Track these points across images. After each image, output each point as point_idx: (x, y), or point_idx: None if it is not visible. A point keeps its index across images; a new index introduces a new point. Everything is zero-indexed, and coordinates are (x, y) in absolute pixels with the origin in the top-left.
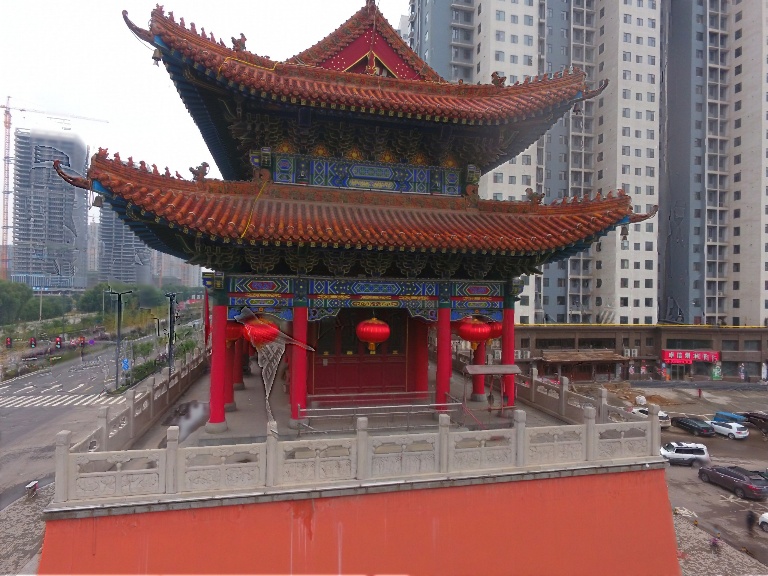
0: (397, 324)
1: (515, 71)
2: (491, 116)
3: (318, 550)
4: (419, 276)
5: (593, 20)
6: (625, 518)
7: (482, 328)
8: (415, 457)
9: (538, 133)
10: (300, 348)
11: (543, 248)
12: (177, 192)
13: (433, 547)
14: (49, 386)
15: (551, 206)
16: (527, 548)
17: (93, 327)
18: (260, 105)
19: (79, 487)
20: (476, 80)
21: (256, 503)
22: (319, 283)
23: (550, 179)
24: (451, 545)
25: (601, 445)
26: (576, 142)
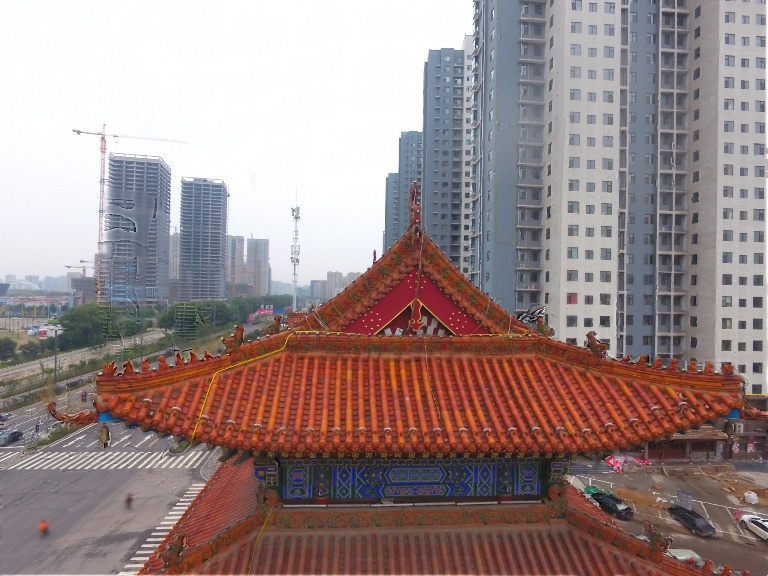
0: None
1: (593, 110)
2: (591, 448)
3: None
4: None
5: (686, 41)
6: None
7: None
8: None
9: None
10: None
11: None
12: None
13: None
14: (119, 438)
15: (684, 566)
16: None
17: None
18: None
19: None
20: (547, 120)
21: None
22: None
23: (634, 224)
24: None
25: None
26: (665, 180)
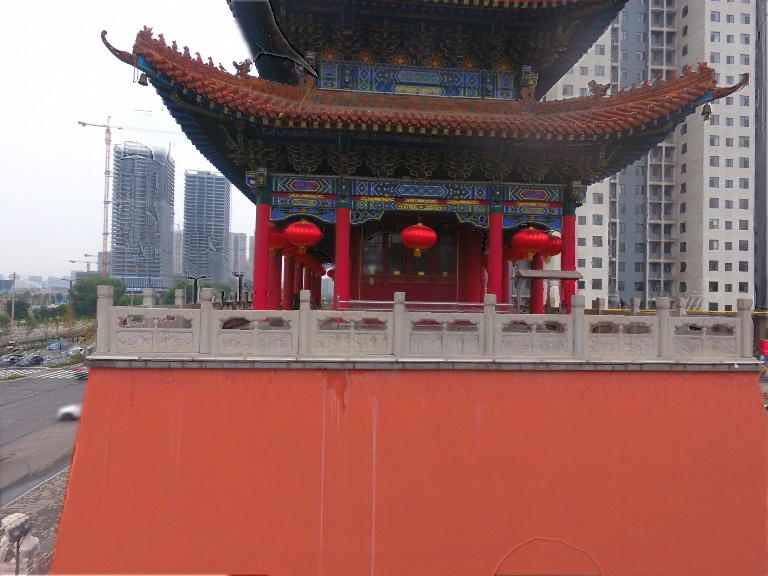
0: (447, 244)
1: None
2: None
3: (351, 423)
4: (468, 179)
5: None
6: (708, 424)
7: (538, 234)
8: (457, 337)
9: (603, 24)
10: (342, 250)
11: (607, 131)
12: (220, 82)
13: (477, 433)
14: None
15: (617, 96)
16: (586, 446)
17: None
18: (304, 6)
19: (119, 340)
20: None
21: (288, 369)
22: (362, 184)
23: None
24: (497, 433)
25: (677, 341)
26: None
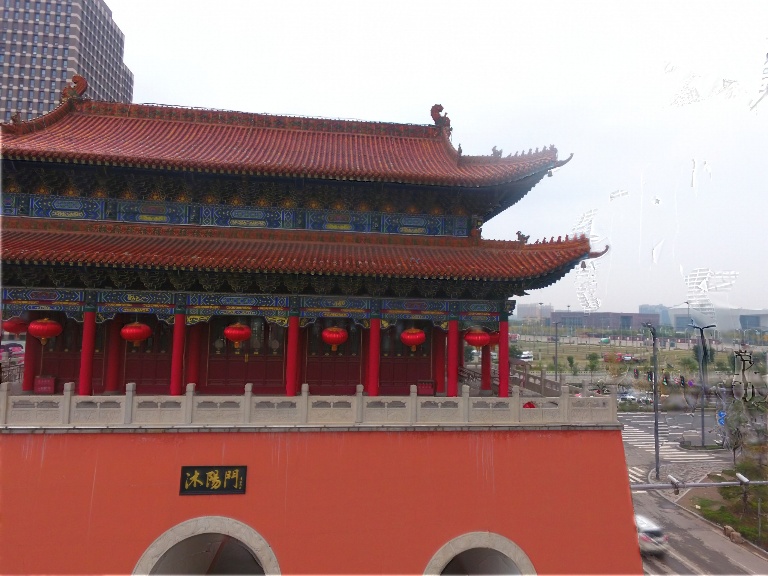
0: None
1: None
2: None
3: None
4: None
5: None
6: None
7: None
8: None
9: None
10: None
11: None
12: None
13: None
14: None
15: None
16: None
17: (688, 366)
18: None
19: None
20: None
21: None
22: None
23: None
24: None
25: None
26: None
